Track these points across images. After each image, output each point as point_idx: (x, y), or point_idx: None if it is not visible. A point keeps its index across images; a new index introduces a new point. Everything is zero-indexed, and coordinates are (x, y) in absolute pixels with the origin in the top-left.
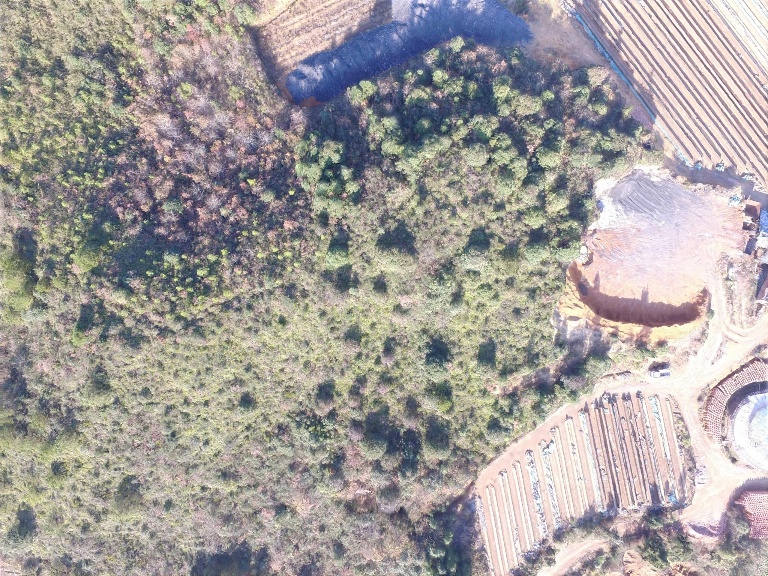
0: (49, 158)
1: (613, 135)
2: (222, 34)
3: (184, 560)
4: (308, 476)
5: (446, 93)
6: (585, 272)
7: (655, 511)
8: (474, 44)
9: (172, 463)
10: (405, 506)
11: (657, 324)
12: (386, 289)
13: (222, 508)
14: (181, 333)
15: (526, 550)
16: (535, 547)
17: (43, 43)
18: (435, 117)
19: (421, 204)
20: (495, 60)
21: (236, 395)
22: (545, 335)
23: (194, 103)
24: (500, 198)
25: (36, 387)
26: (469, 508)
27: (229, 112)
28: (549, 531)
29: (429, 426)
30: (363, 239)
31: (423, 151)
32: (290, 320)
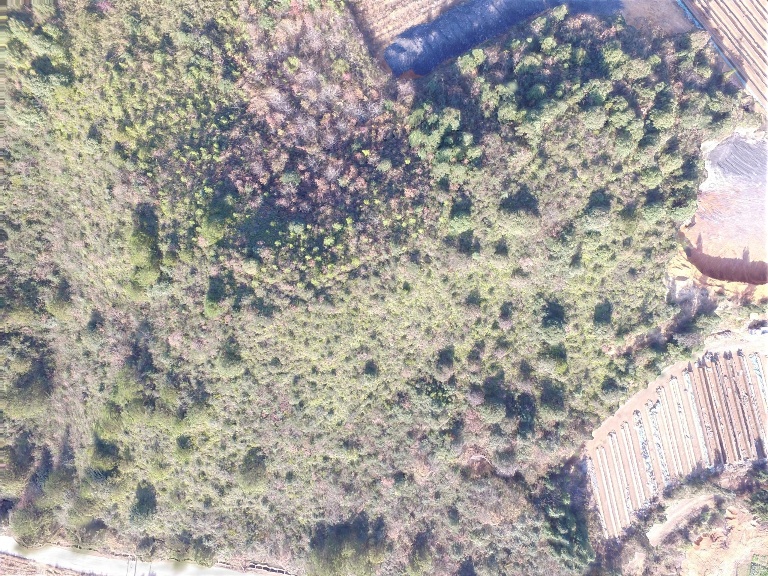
0: (163, 134)
1: (721, 97)
2: (324, 9)
3: (302, 532)
4: (427, 443)
5: (556, 60)
6: (688, 234)
7: (760, 465)
8: (569, 14)
9: (297, 433)
10: (521, 469)
11: (760, 282)
12: (507, 253)
13: (343, 478)
14: (313, 301)
15: (637, 508)
16: (646, 505)
17: (152, 20)
18: (547, 83)
19: (542, 168)
20: (601, 27)
21: (361, 363)
22: (657, 295)
23: (302, 77)
24: (618, 160)
25: (165, 361)
26: (581, 469)
27: (336, 86)
28: (659, 489)
29: (543, 389)
30: (484, 204)
31: (544, 115)
32: (414, 287)
